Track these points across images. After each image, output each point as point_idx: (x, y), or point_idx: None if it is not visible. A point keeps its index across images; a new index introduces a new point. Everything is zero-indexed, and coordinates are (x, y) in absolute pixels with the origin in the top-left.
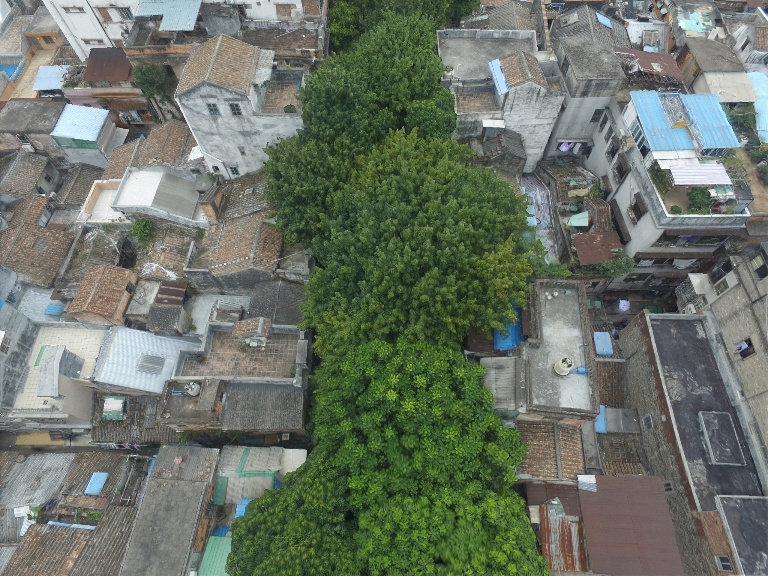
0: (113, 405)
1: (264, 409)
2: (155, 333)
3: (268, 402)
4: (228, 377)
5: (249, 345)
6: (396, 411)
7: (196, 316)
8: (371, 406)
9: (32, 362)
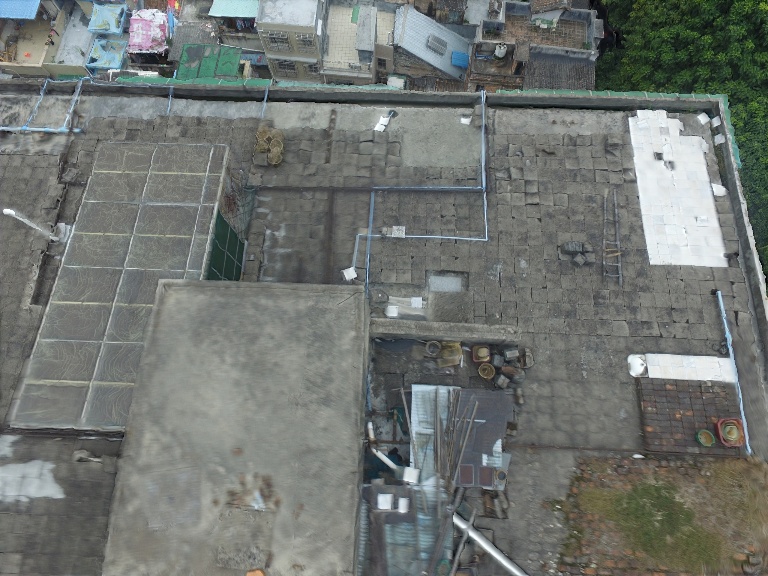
0: (396, 83)
1: (559, 77)
2: (438, 19)
3: (563, 72)
4: (531, 44)
5: (539, 26)
6: (765, 21)
7: (466, 14)
8: (735, 21)
9: (330, 33)
